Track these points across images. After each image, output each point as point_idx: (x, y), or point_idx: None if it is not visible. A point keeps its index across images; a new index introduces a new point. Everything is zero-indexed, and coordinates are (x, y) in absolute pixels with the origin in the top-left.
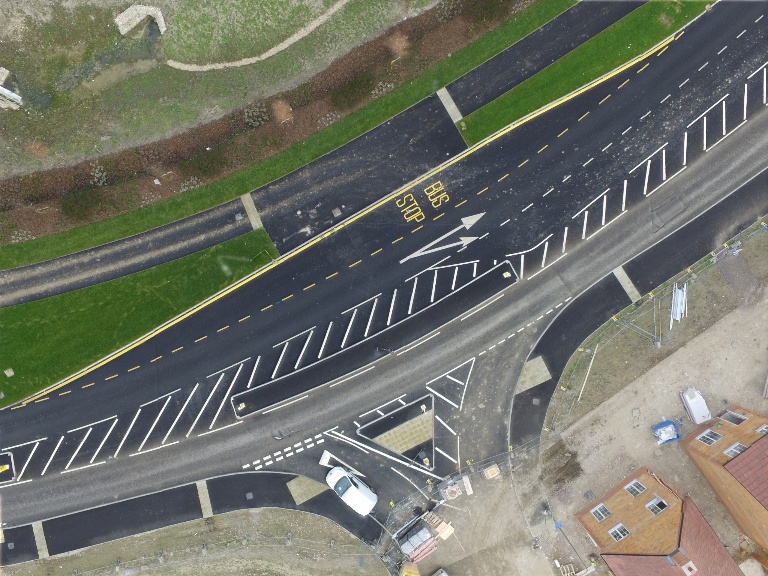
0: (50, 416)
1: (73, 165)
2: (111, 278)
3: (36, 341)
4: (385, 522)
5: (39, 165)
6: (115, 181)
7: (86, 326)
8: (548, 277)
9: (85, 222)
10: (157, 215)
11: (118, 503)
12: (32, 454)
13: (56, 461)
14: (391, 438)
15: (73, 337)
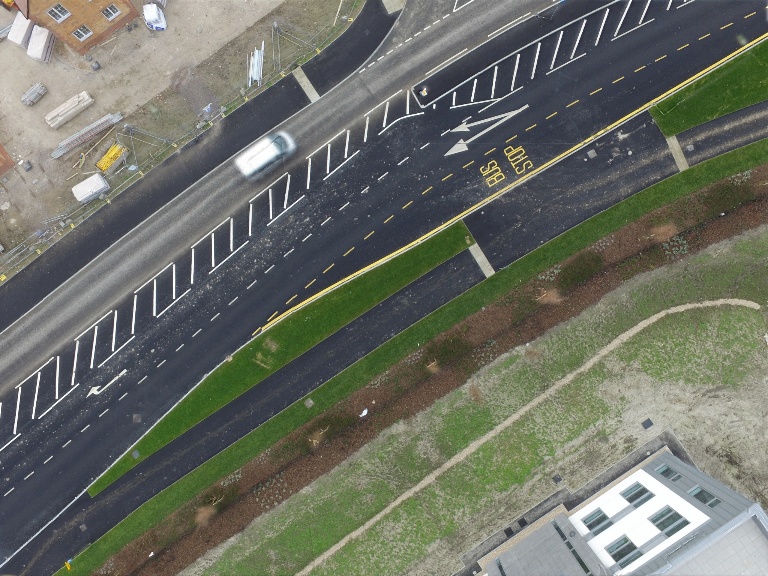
0: None
1: None
2: None
3: None
4: None
5: None
6: None
7: None
8: (382, 92)
9: None
10: None
11: None
12: None
13: None
14: None
15: None
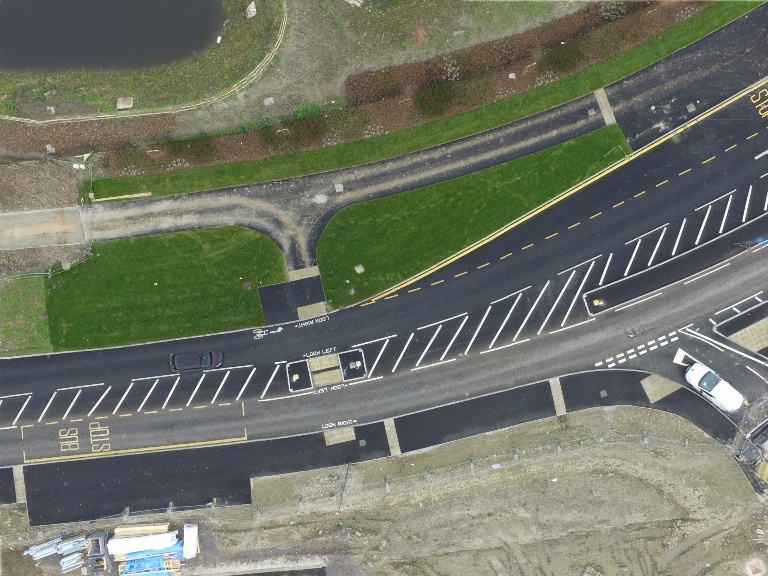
0: (400, 313)
1: (424, 60)
2: (461, 174)
3: (387, 237)
4: (739, 421)
5: (390, 60)
6: (466, 76)
7: (437, 222)
8: None
9: (437, 117)
10: (510, 110)
11: (470, 400)
12: (382, 351)
13: (406, 358)
14: (747, 336)
15: (424, 233)
